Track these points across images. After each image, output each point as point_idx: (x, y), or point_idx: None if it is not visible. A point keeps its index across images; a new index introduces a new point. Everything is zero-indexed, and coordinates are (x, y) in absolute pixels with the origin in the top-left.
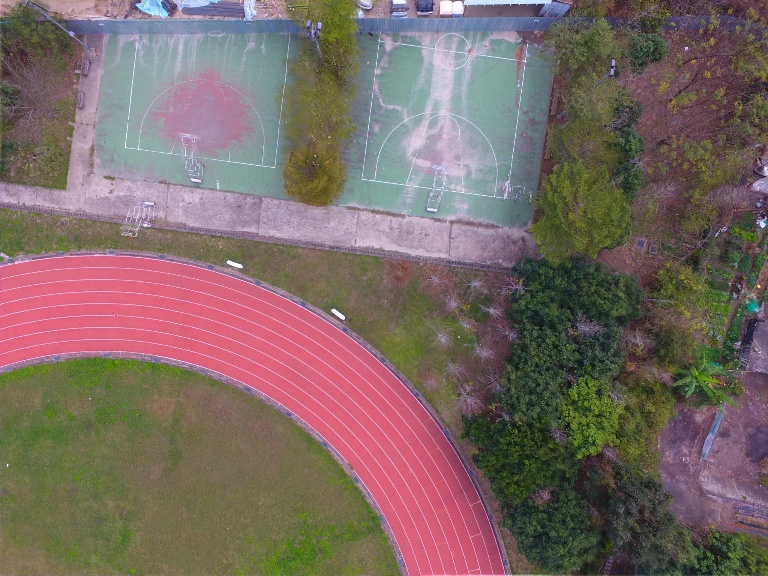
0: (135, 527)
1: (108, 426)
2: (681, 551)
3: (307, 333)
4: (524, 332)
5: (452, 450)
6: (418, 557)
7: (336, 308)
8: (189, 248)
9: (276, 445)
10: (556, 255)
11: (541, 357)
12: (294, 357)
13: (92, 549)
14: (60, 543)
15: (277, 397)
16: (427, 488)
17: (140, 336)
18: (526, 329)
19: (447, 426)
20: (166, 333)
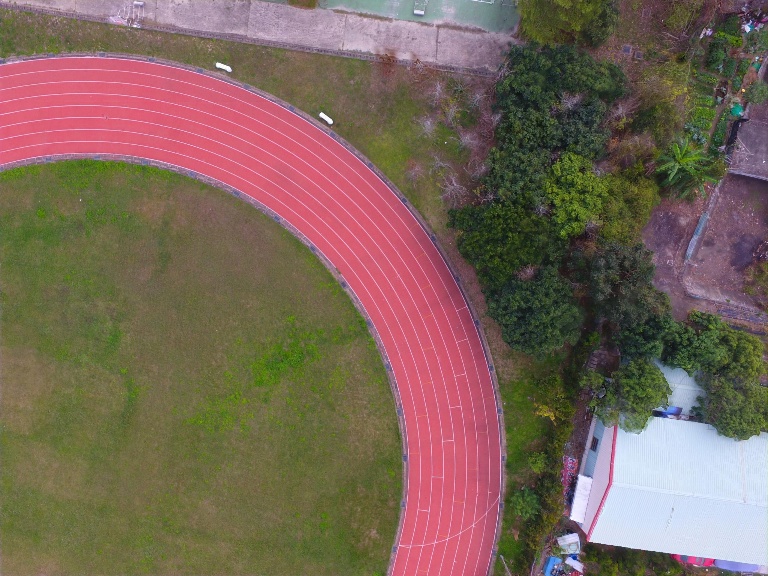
0: (125, 328)
1: (99, 227)
2: (661, 306)
3: (295, 138)
4: (508, 114)
5: (439, 256)
6: (405, 361)
7: (324, 112)
8: (178, 51)
9: (264, 248)
10: (540, 34)
11: (525, 135)
12: (282, 161)
13: (83, 349)
14: (51, 342)
15: (266, 201)
16: (414, 293)
17: (130, 139)
18: (510, 111)
19: (434, 232)
20: (156, 136)
